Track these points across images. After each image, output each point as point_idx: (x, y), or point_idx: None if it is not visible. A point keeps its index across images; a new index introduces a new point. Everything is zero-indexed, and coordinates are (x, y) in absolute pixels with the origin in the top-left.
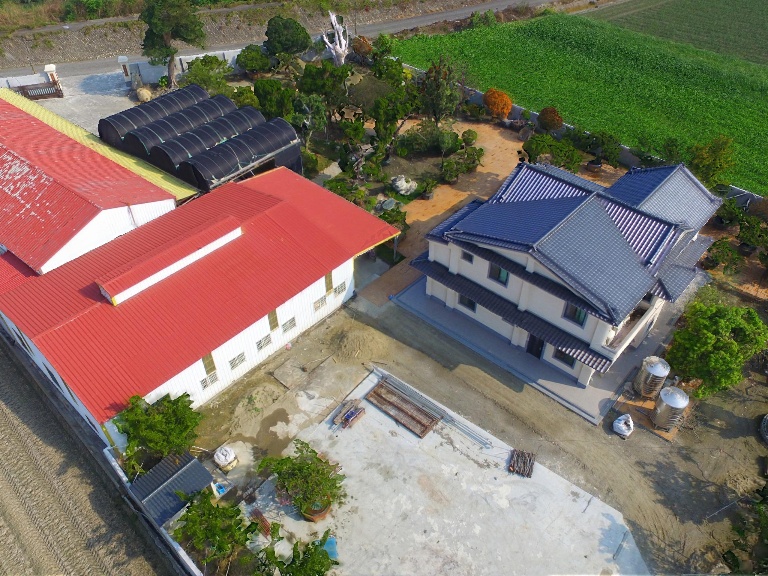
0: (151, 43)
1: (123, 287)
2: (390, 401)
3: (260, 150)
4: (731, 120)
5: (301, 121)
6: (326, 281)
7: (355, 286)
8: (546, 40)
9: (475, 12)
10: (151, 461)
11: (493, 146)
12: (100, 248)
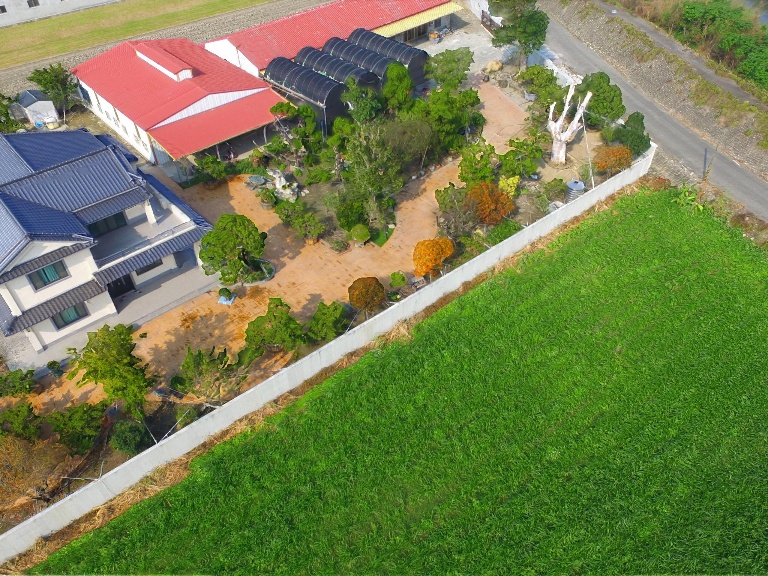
0: None
1: (138, 48)
2: None
3: (300, 86)
4: None
5: None
6: None
7: (166, 166)
8: None
9: None
10: (76, 109)
11: (361, 265)
12: (212, 54)
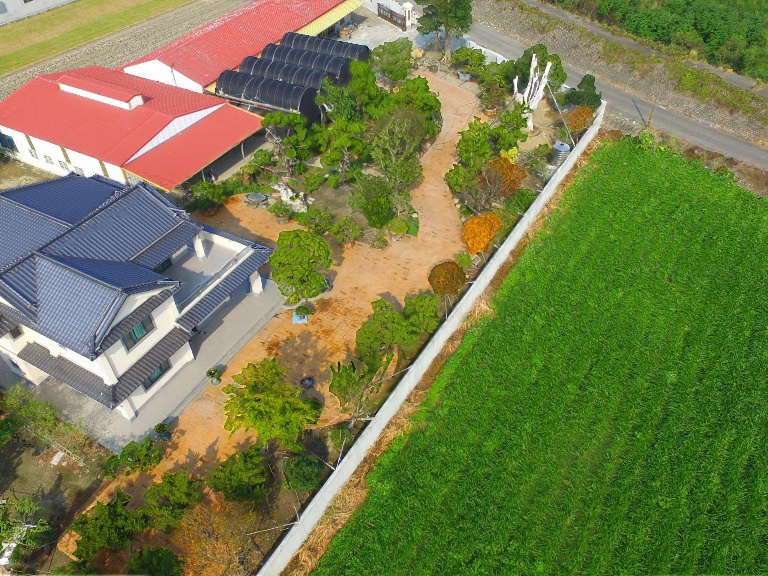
0: (428, 12)
1: (63, 81)
2: None
3: (264, 96)
4: (646, 569)
5: (318, 102)
6: (102, 166)
7: None
8: None
9: None
10: None
11: (409, 256)
12: (141, 78)
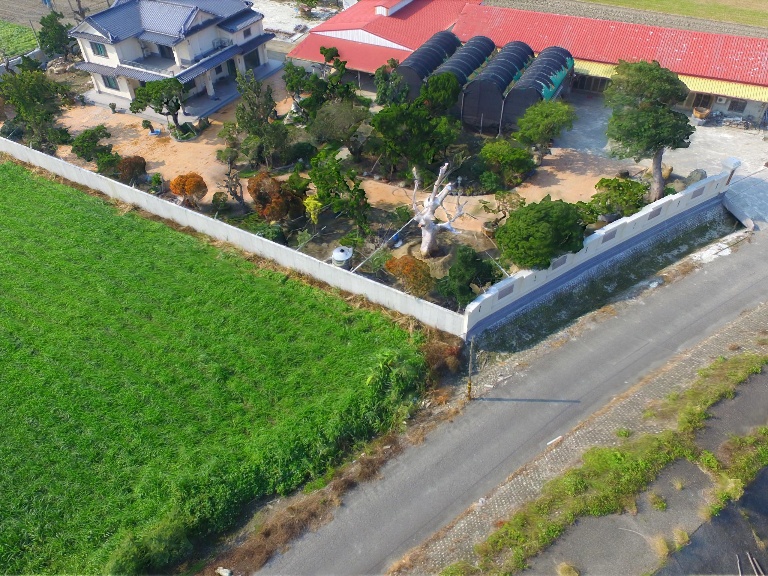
0: None
1: None
2: (283, 33)
3: None
4: None
5: None
6: None
7: None
8: (8, 469)
9: (168, 530)
10: None
11: (205, 173)
12: None
